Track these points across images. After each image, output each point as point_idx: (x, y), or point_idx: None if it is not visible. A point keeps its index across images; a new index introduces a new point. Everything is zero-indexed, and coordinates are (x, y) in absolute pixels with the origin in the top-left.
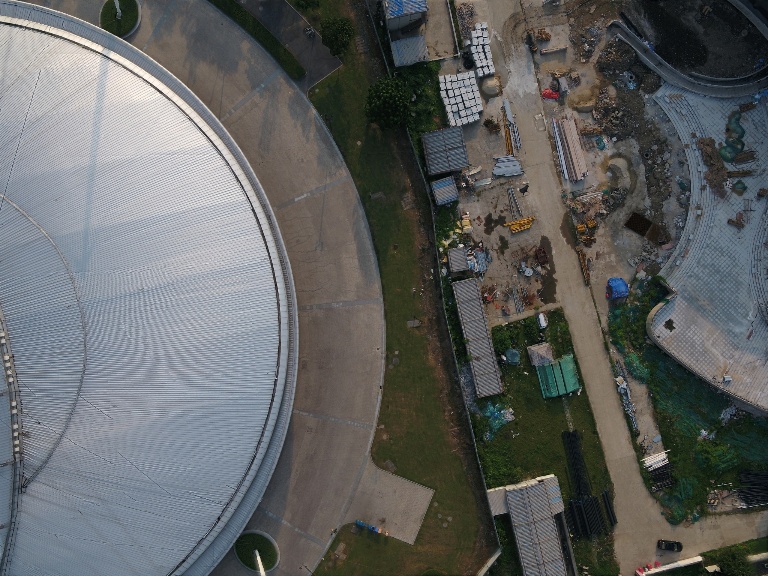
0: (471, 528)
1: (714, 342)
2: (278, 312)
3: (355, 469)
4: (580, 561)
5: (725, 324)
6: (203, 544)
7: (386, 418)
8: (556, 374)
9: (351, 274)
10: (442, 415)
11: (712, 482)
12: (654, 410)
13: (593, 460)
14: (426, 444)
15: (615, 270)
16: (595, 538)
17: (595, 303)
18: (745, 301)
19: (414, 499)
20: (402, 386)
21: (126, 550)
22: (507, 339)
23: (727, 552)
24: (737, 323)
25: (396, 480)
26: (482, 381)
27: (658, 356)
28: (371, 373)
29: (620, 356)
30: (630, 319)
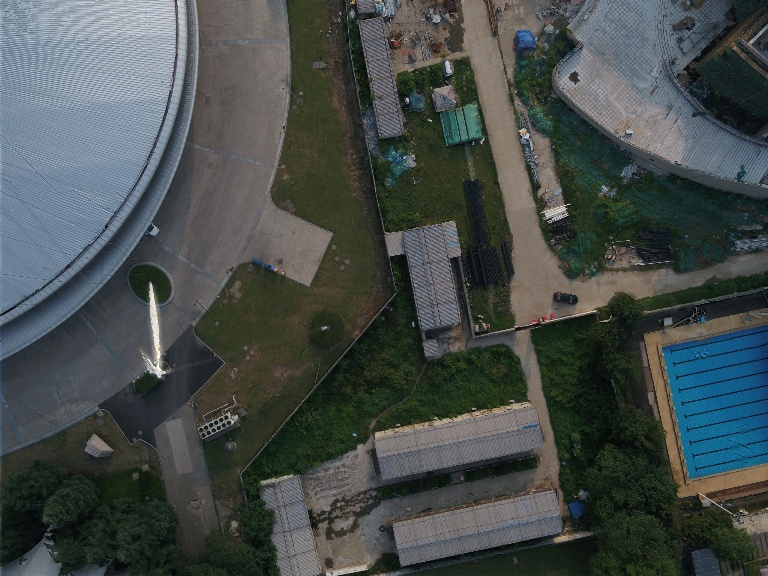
0: (368, 272)
1: (618, 96)
2: (176, 24)
3: (254, 208)
4: (476, 311)
5: (629, 79)
6: (89, 251)
7: (288, 158)
8: (459, 120)
9: (259, 12)
10: (344, 158)
11: (611, 238)
12: (556, 164)
13: (493, 210)
14: (326, 186)
15: (523, 22)
16: (492, 289)
17: (502, 54)
18: (650, 57)
19: (312, 241)
20: (305, 126)
21: (7, 243)
22: (411, 80)
23: (618, 294)
24: (641, 79)
25: (295, 221)
26: (384, 120)
27: (562, 110)
28: (274, 113)
29: (524, 108)
30: (536, 73)
